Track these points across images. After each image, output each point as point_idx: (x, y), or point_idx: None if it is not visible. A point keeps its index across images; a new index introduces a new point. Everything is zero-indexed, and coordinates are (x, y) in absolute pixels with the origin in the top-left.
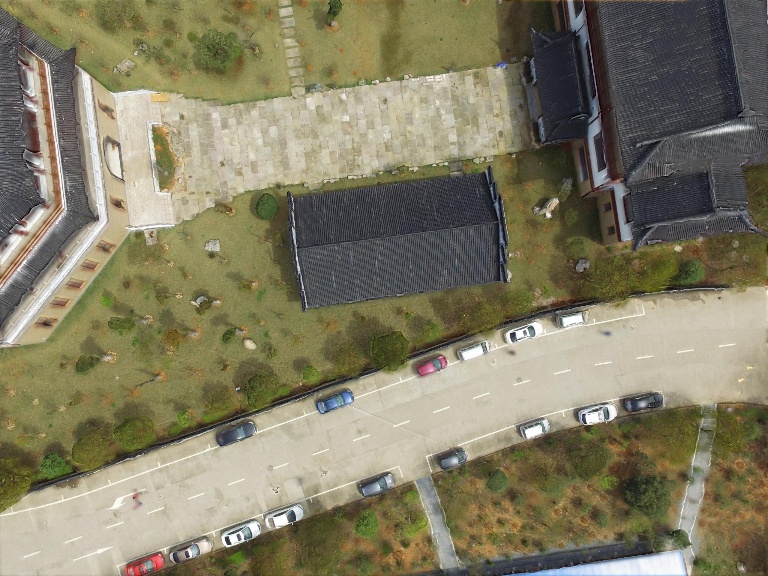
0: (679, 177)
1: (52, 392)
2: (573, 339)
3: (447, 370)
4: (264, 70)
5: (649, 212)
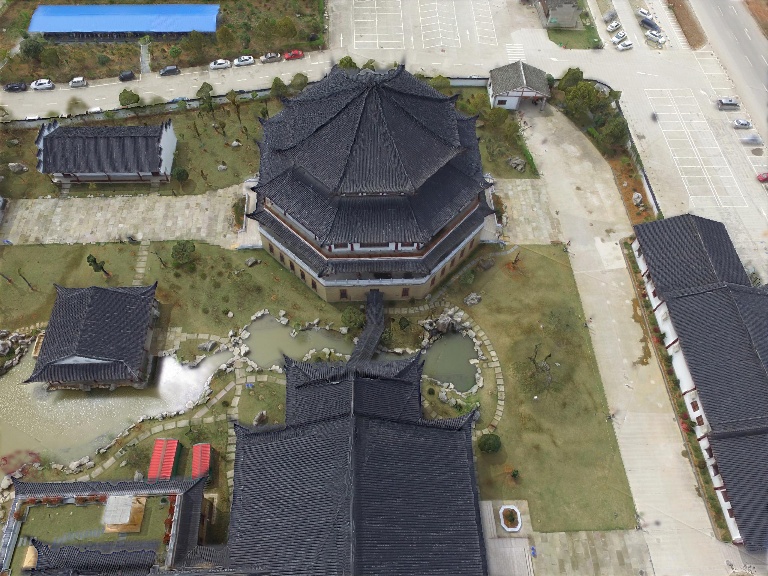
0: None
1: None
2: None
3: None
4: (163, 255)
5: None
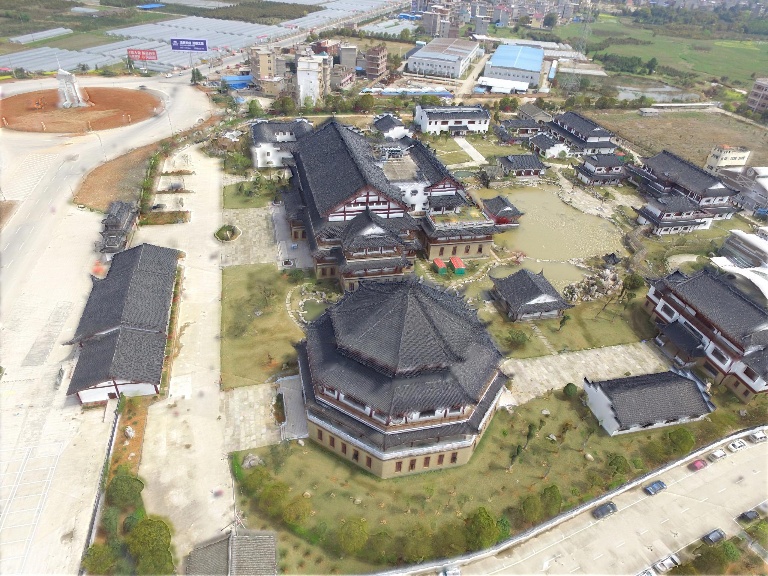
0: (766, 354)
1: (480, 491)
2: (767, 449)
3: (710, 468)
4: (535, 346)
5: (764, 368)
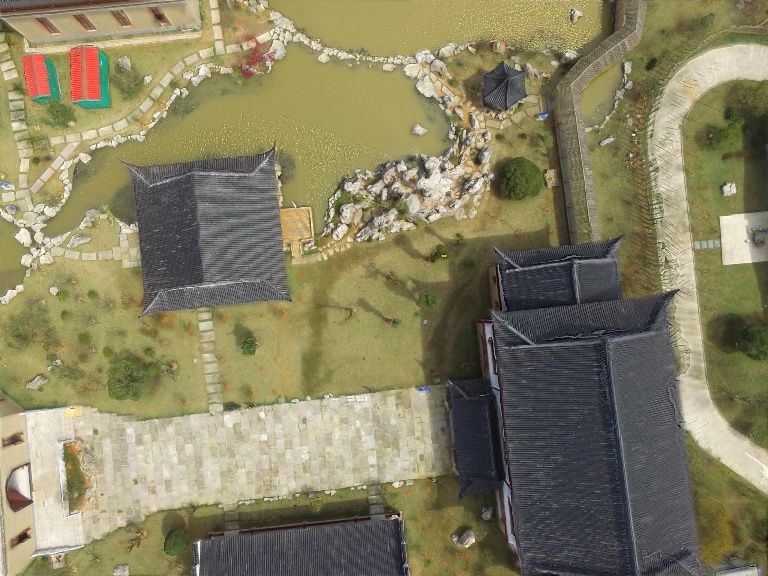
0: None
1: None
2: None
3: None
4: (181, 387)
5: None
